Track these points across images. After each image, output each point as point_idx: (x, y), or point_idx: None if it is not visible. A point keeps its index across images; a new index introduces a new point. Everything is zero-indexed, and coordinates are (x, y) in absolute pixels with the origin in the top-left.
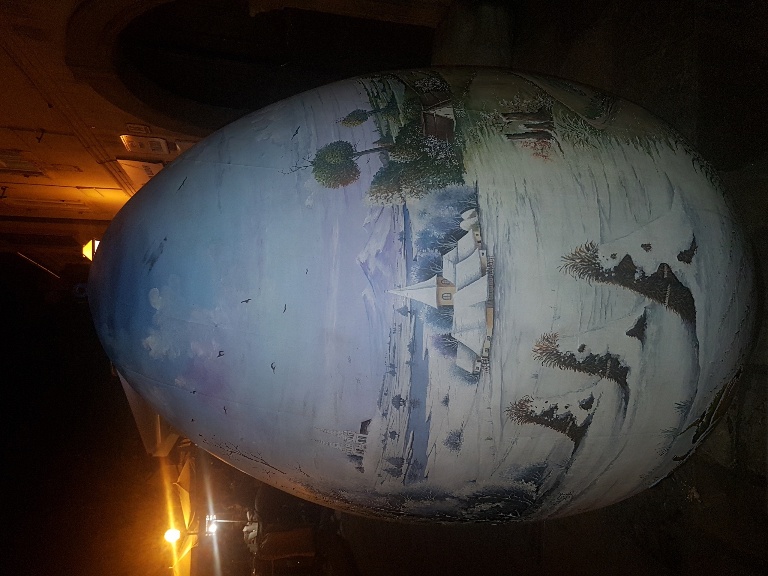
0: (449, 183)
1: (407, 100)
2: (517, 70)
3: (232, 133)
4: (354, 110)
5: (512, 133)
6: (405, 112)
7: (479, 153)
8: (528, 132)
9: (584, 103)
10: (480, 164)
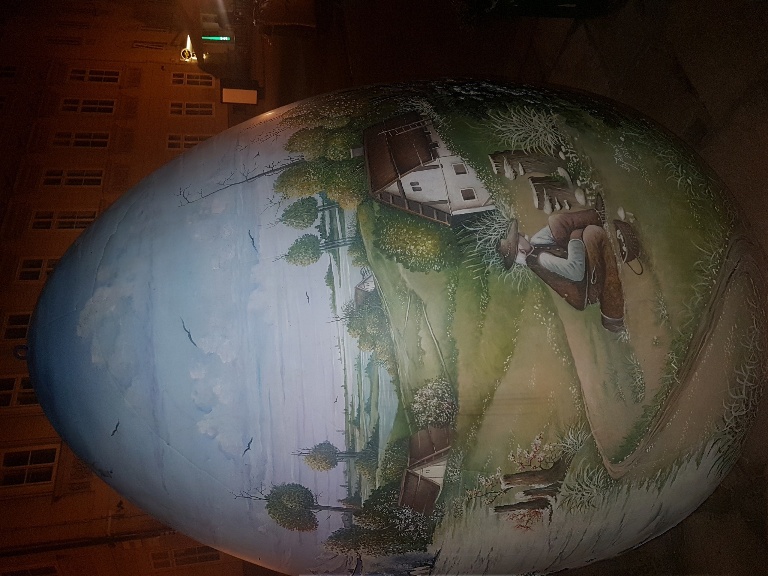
0: (410, 551)
1: (393, 443)
2: (586, 308)
3: (166, 376)
4: (322, 442)
5: (503, 505)
6: (385, 467)
7: (454, 528)
8: (523, 502)
9: (627, 428)
10: (450, 538)
